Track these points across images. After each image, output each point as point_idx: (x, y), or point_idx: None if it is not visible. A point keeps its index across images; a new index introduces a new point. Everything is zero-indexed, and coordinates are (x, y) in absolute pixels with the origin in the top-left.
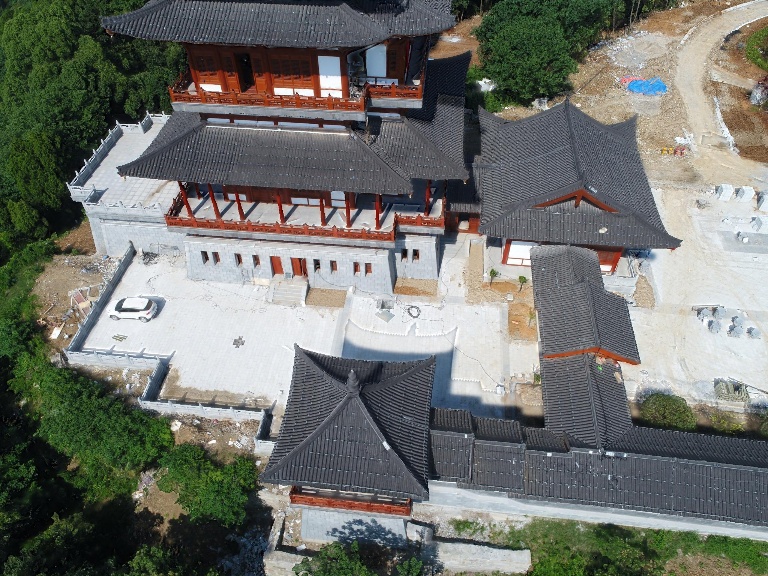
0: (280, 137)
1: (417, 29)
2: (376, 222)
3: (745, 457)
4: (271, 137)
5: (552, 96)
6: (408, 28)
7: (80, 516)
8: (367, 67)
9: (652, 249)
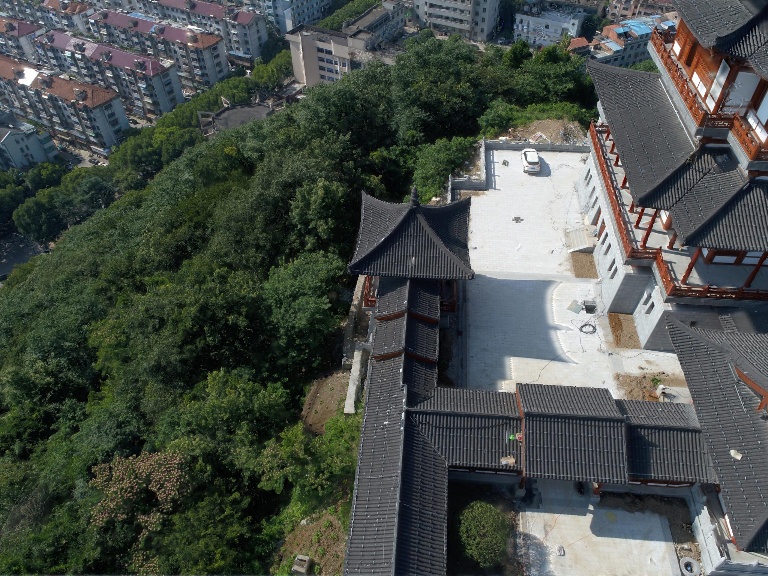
0: (670, 117)
1: (763, 68)
2: (644, 239)
3: (415, 567)
4: (667, 112)
5: None
6: (764, 65)
7: (383, 188)
8: (761, 105)
9: None
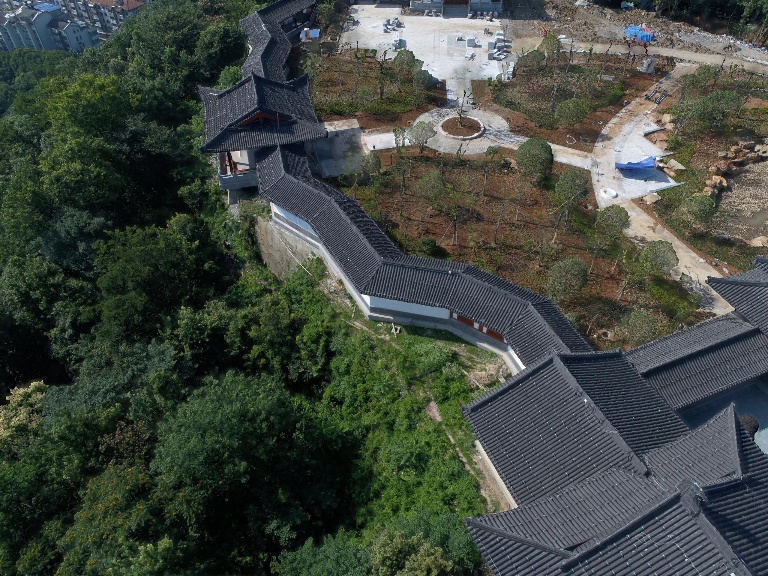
0: None
1: None
2: None
3: None
4: None
5: (595, 2)
6: None
7: None
8: None
9: (444, 18)
